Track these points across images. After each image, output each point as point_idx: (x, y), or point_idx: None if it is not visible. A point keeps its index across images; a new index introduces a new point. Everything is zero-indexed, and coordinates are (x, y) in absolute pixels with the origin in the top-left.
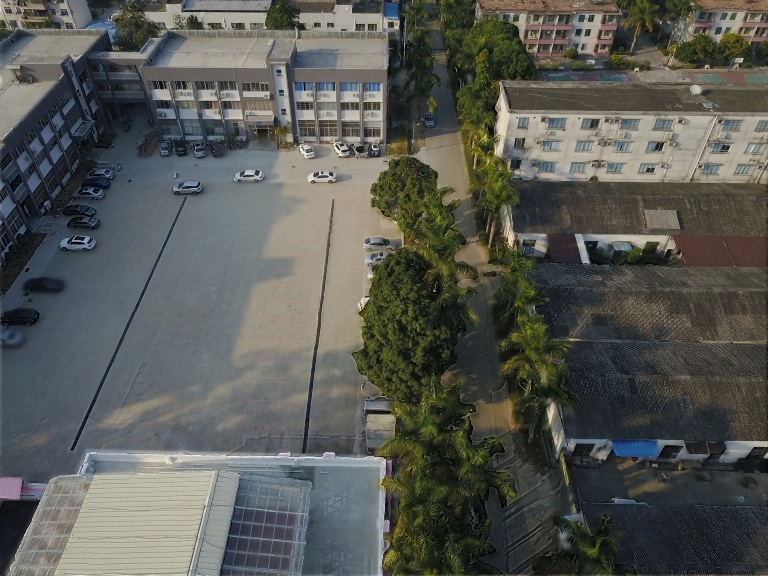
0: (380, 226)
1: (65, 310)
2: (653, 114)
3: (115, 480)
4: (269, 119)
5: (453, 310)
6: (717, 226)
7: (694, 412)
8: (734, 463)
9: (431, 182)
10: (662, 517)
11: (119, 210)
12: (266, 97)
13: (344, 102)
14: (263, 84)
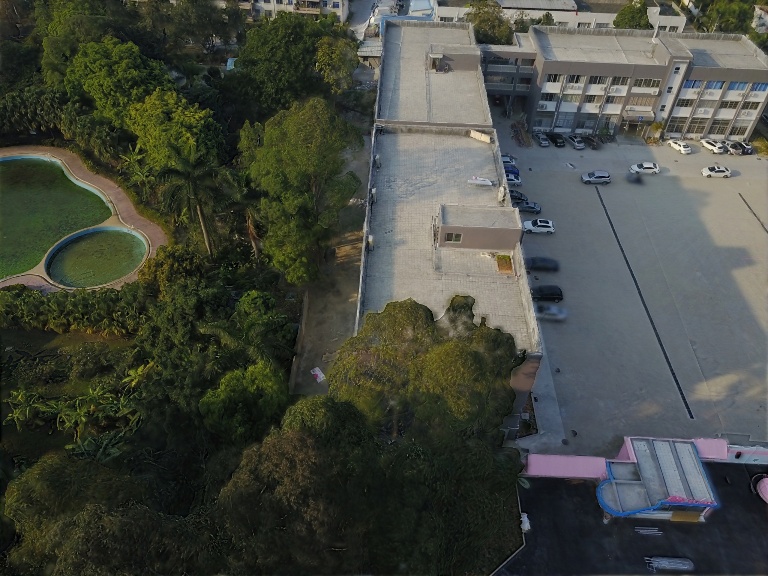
0: None
1: (576, 289)
2: None
3: None
4: (649, 114)
5: None
6: None
7: None
8: None
9: None
10: None
11: (544, 197)
12: (654, 93)
13: (725, 101)
14: (655, 81)
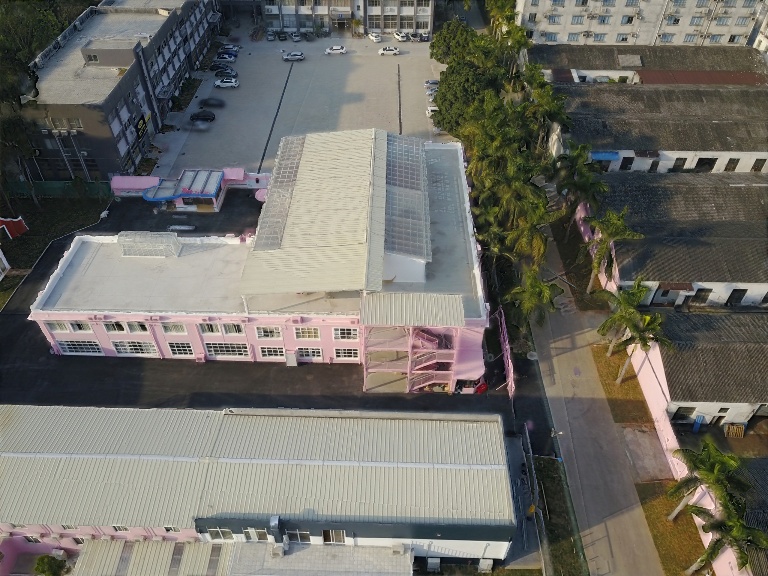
0: (434, 77)
1: (230, 116)
2: None
3: (319, 134)
4: (348, 13)
5: (494, 86)
6: (667, 65)
7: (641, 137)
8: None
9: None
10: (618, 174)
11: (248, 69)
12: None
13: (403, 0)
14: None
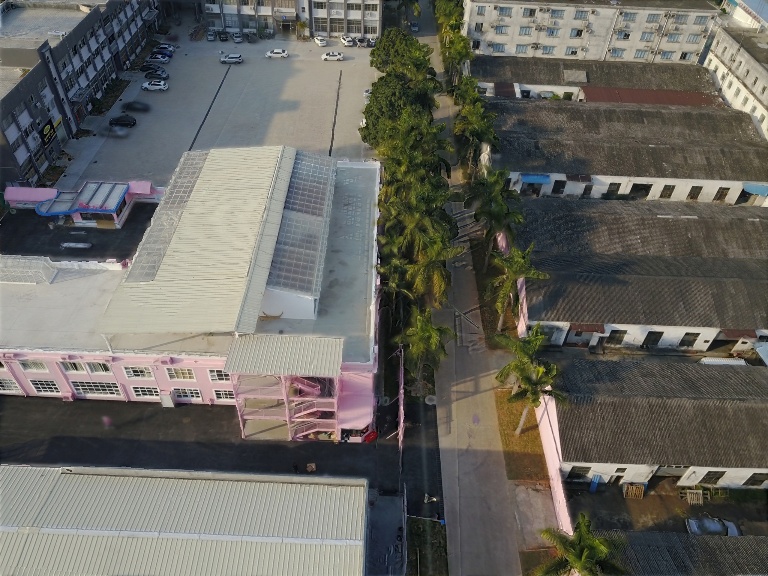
0: None
1: (153, 121)
2: (574, 6)
3: (224, 150)
4: (292, 15)
5: (425, 101)
6: (613, 82)
7: (573, 160)
8: (600, 198)
9: (414, 42)
10: (544, 200)
11: (181, 71)
12: None
13: (350, 3)
14: None
